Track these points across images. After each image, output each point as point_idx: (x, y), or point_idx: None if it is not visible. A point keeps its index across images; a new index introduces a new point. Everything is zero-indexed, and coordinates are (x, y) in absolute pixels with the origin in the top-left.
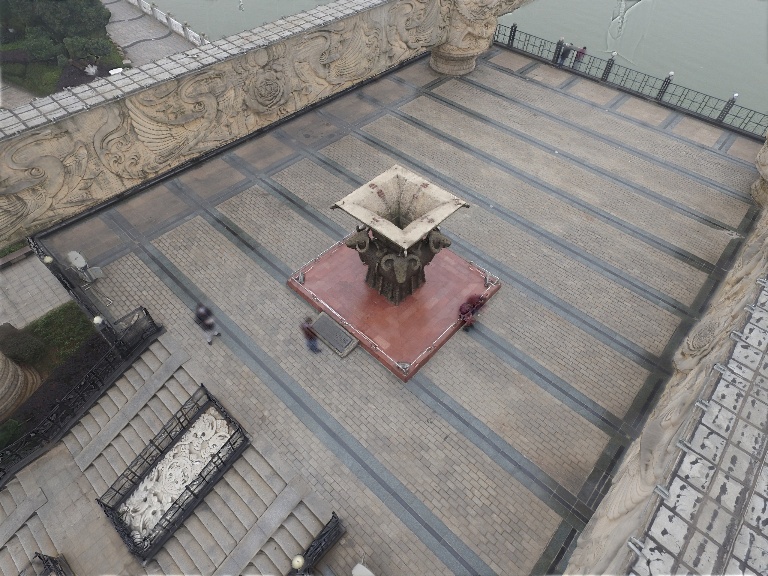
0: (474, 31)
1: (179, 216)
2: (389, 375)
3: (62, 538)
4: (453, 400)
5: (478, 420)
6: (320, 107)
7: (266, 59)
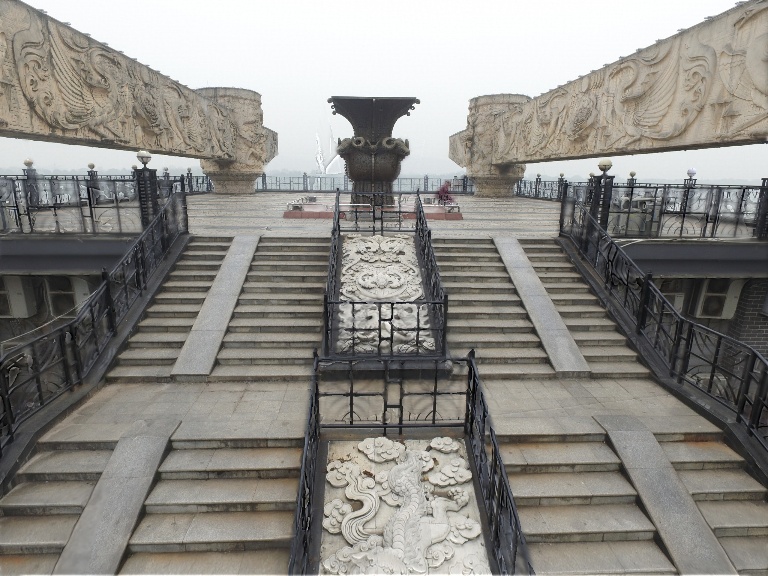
0: (256, 151)
1: None
2: (447, 220)
3: (282, 425)
4: None
5: None
6: None
7: (147, 79)
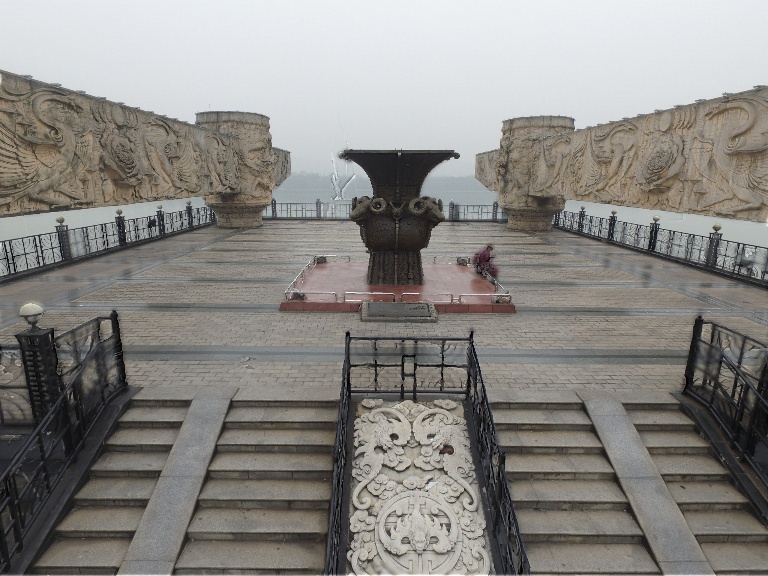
0: (263, 181)
1: (5, 318)
2: (495, 315)
3: None
4: (565, 307)
5: (600, 308)
6: (132, 248)
7: (122, 120)
